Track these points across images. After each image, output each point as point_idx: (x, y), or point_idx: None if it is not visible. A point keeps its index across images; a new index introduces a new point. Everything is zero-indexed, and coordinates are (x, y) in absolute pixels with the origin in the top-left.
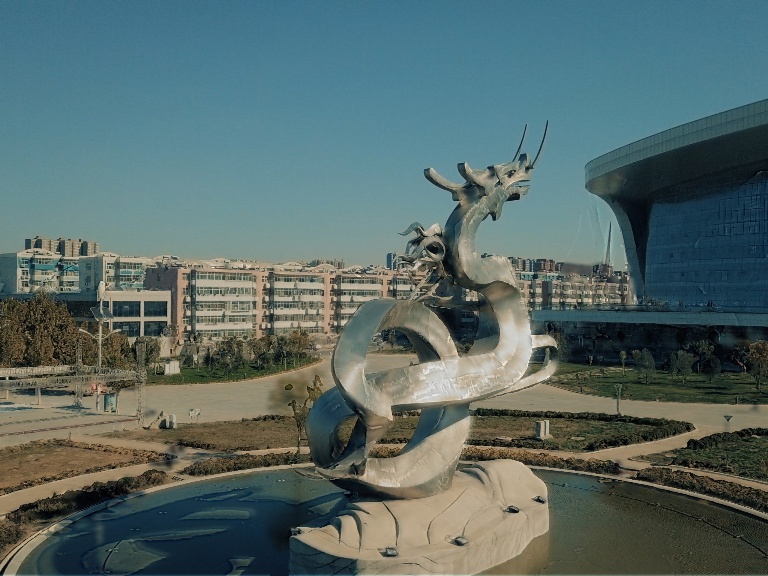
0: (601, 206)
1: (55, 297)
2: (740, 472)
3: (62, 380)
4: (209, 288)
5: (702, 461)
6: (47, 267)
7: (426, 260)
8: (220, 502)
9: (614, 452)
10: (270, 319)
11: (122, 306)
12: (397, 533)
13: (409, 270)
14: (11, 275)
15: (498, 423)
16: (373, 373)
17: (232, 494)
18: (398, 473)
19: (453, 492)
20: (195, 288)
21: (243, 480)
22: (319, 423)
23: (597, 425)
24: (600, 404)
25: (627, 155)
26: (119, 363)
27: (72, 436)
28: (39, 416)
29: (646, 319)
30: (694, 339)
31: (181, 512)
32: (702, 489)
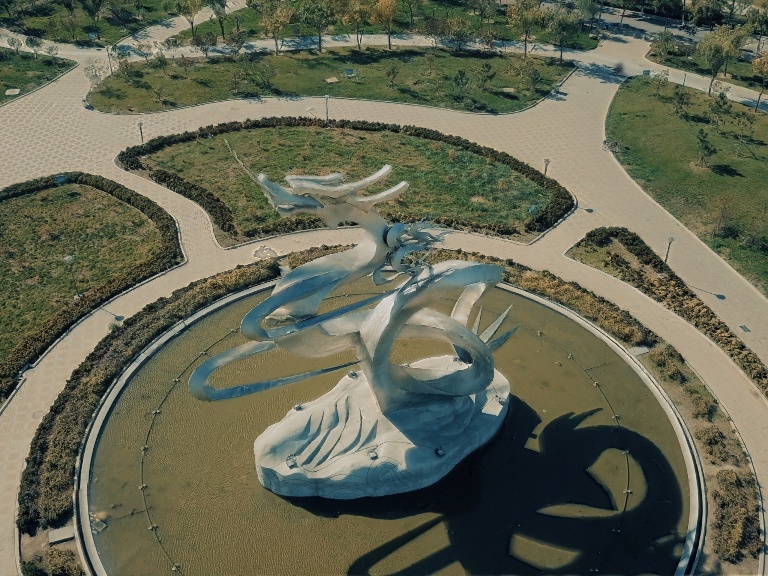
0: None
1: None
2: None
3: None
4: None
5: None
6: None
7: None
8: None
9: None
10: None
11: None
12: None
13: None
14: None
15: None
16: (447, 329)
17: None
18: None
19: None
20: None
21: None
22: None
23: None
24: None
25: None
26: None
27: None
28: None
29: None
30: None
31: (577, 570)
32: None
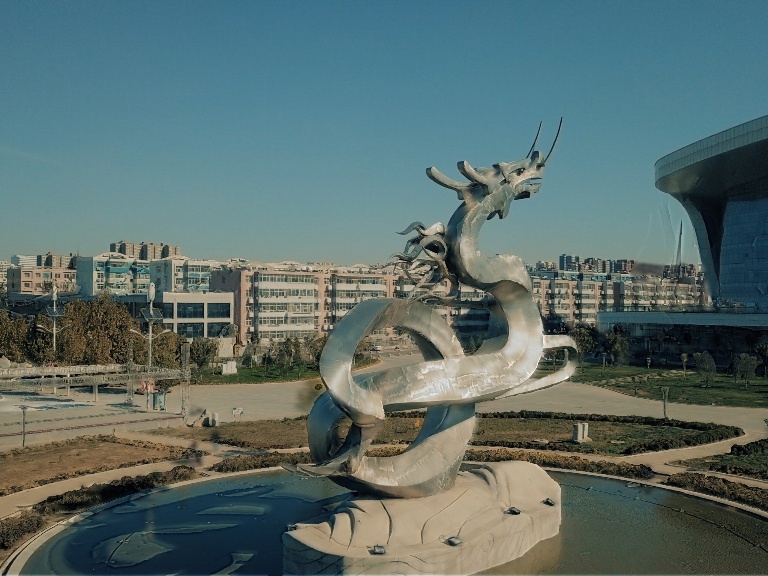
0: (673, 205)
1: (116, 299)
2: None
3: (108, 378)
4: (272, 290)
5: (741, 467)
6: (121, 270)
7: (426, 259)
8: (239, 498)
9: (652, 456)
10: (332, 320)
11: (186, 308)
12: (390, 531)
13: (406, 269)
14: (88, 278)
15: (539, 425)
16: None
17: (253, 491)
18: (396, 472)
19: (454, 492)
20: (258, 290)
21: (268, 477)
22: (318, 421)
23: (642, 429)
24: (651, 408)
25: (698, 152)
26: (167, 362)
27: (118, 432)
28: (89, 413)
29: (716, 321)
30: None
31: (199, 507)
32: (732, 496)
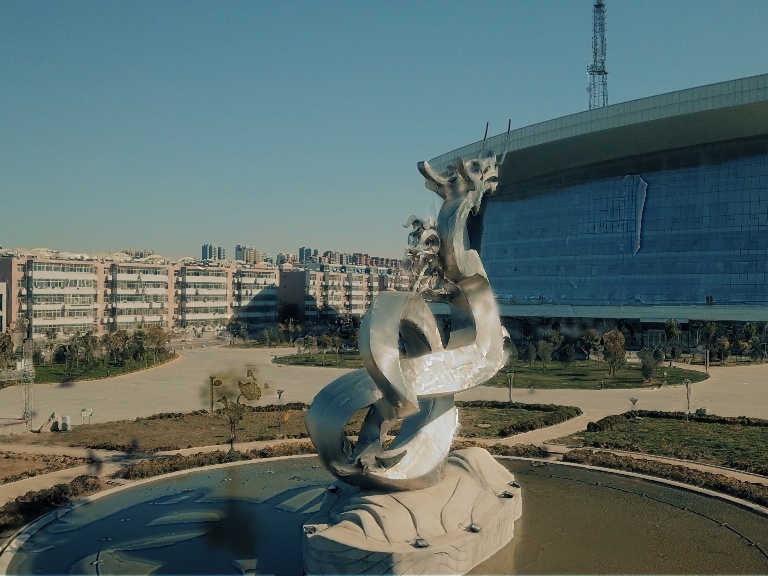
0: (439, 203)
1: None
2: (647, 451)
3: None
4: (47, 280)
5: (611, 442)
6: None
7: (426, 253)
8: (177, 505)
9: (526, 437)
10: (112, 313)
11: None
12: (415, 524)
13: None
14: None
15: None
16: None
17: (184, 496)
18: (403, 465)
19: (450, 481)
20: (32, 280)
21: (185, 481)
22: (327, 418)
23: (494, 412)
24: (482, 392)
25: (467, 155)
26: None
27: None
28: None
29: None
30: (534, 330)
31: (144, 518)
32: (629, 467)
